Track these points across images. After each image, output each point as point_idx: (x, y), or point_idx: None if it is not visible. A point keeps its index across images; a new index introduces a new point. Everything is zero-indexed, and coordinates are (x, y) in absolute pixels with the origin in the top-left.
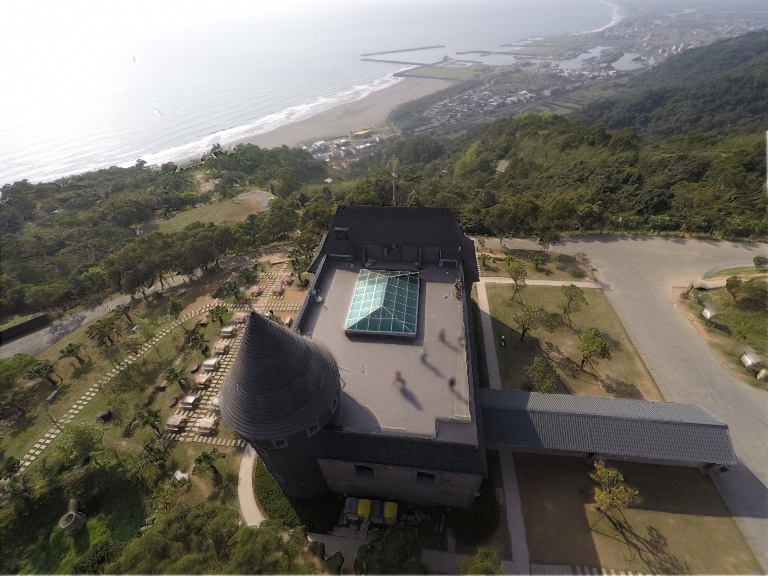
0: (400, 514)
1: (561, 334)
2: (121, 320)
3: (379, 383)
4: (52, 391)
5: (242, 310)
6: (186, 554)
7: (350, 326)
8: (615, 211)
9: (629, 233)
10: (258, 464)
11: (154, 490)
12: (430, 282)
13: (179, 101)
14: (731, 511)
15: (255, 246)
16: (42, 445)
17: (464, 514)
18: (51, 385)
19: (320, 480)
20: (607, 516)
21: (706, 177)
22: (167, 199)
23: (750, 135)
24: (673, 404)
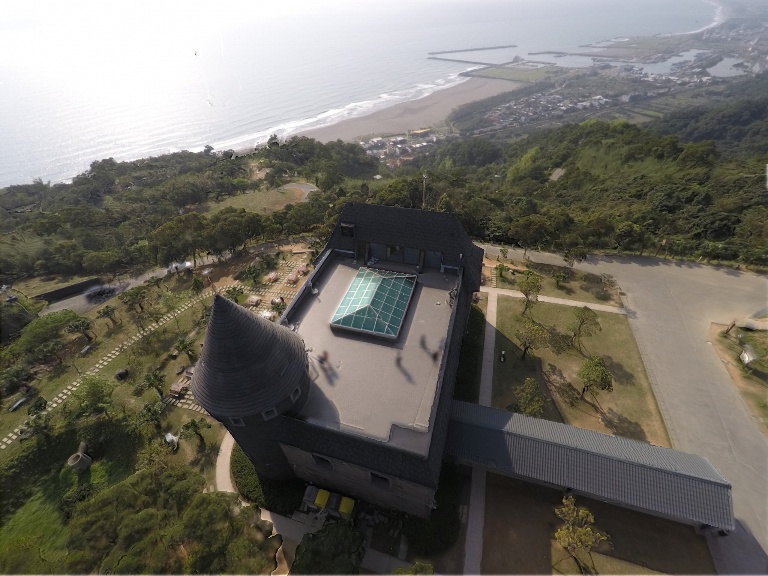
0: (359, 511)
1: (568, 358)
2: (153, 290)
3: (350, 380)
4: (86, 346)
5: (257, 294)
6: None
7: (335, 321)
8: (666, 232)
9: (673, 258)
10: None
11: (147, 447)
12: (427, 287)
13: (230, 93)
14: None
15: None
16: (69, 391)
17: (421, 524)
18: (87, 340)
19: (285, 464)
20: (574, 557)
21: None
22: (221, 184)
23: None
24: (673, 451)
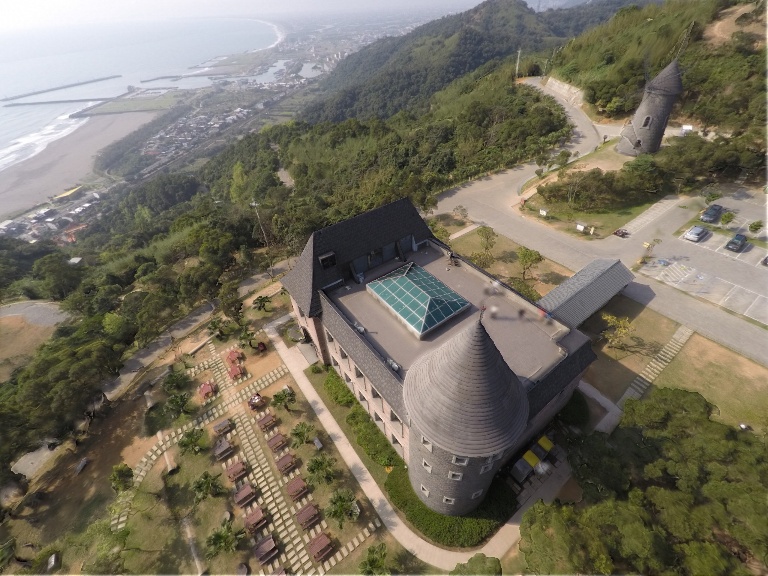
0: None
1: (492, 265)
2: (12, 571)
3: None
4: None
5: (213, 419)
6: None
7: (422, 329)
8: None
9: (458, 185)
10: (414, 521)
11: None
12: (424, 266)
13: None
14: (644, 304)
15: None
16: None
17: (568, 409)
18: None
19: None
20: None
21: (459, 136)
22: None
23: (449, 105)
24: (589, 265)
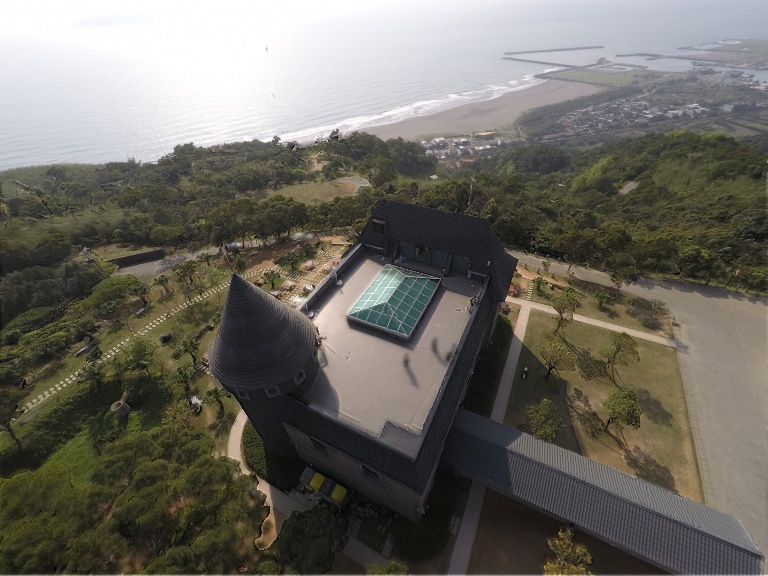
0: (352, 502)
1: (598, 385)
2: None
3: (356, 372)
4: (142, 308)
5: (292, 279)
6: (168, 460)
7: (352, 313)
8: (746, 263)
9: (747, 292)
10: None
11: None
12: (450, 291)
13: (292, 87)
14: None
15: (331, 226)
16: None
17: (410, 526)
18: (143, 304)
19: (288, 442)
20: None
21: None
22: (280, 173)
23: None
24: (700, 505)
